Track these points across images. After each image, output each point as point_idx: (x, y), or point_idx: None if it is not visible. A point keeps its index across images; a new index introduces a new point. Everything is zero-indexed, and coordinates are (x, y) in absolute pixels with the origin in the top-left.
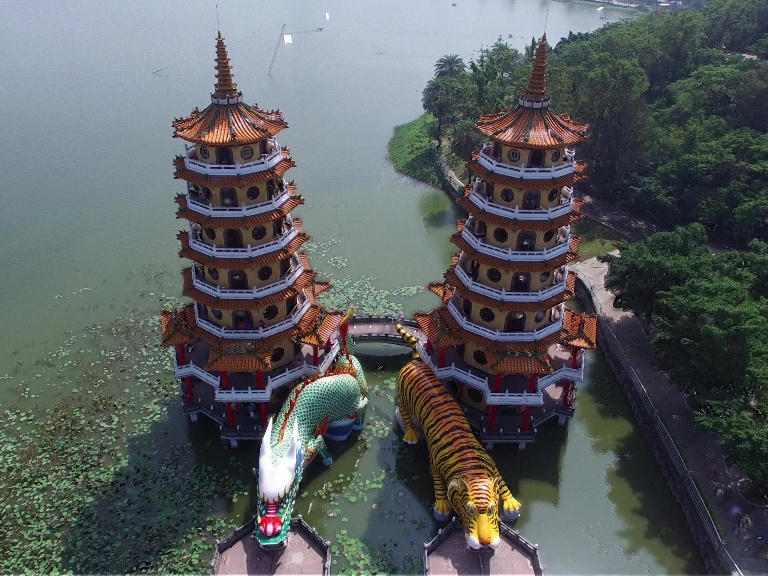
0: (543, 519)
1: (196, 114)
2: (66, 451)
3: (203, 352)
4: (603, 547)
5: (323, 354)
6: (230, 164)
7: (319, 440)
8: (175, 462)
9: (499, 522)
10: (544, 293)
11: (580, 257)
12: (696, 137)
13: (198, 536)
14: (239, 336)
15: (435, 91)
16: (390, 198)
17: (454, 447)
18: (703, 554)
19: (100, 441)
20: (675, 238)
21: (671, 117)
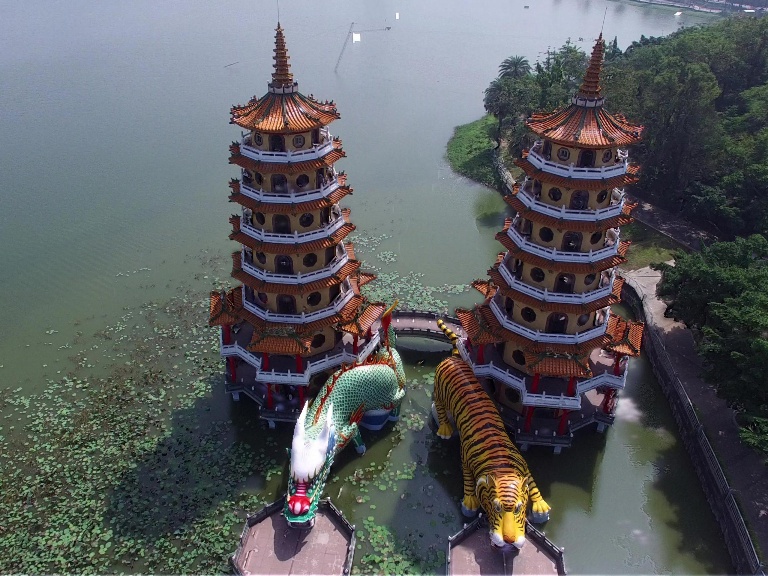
0: (573, 525)
1: (253, 102)
2: (115, 419)
3: (248, 334)
4: (634, 559)
5: (363, 344)
6: (282, 151)
7: (353, 427)
8: (215, 438)
9: (526, 522)
10: (588, 296)
11: (634, 265)
12: (767, 147)
13: (231, 509)
14: (282, 320)
15: (497, 92)
16: (445, 197)
17: (486, 444)
18: (739, 575)
19: (147, 412)
20: (734, 249)
21: (742, 125)
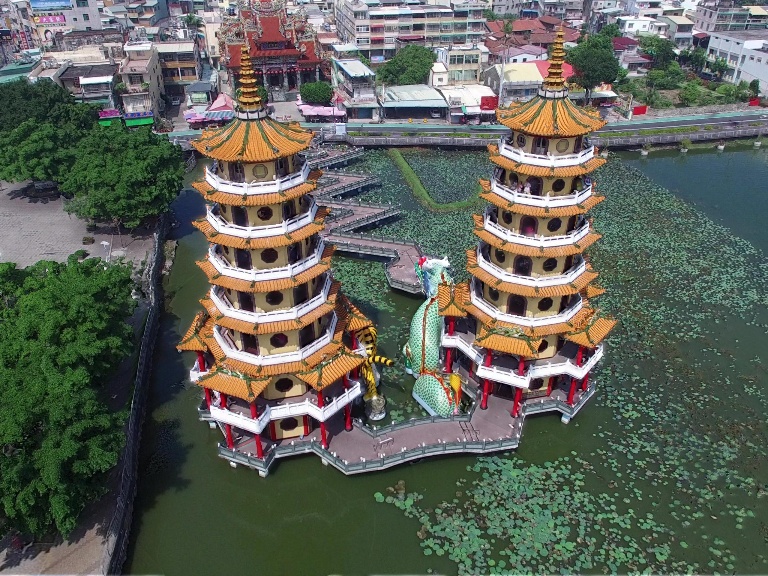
0: None
1: None
2: None
3: None
4: None
5: None
6: None
7: None
8: None
9: None
10: None
11: None
12: None
13: None
14: None
15: None
16: None
17: None
18: None
19: None
20: (8, 406)
21: None
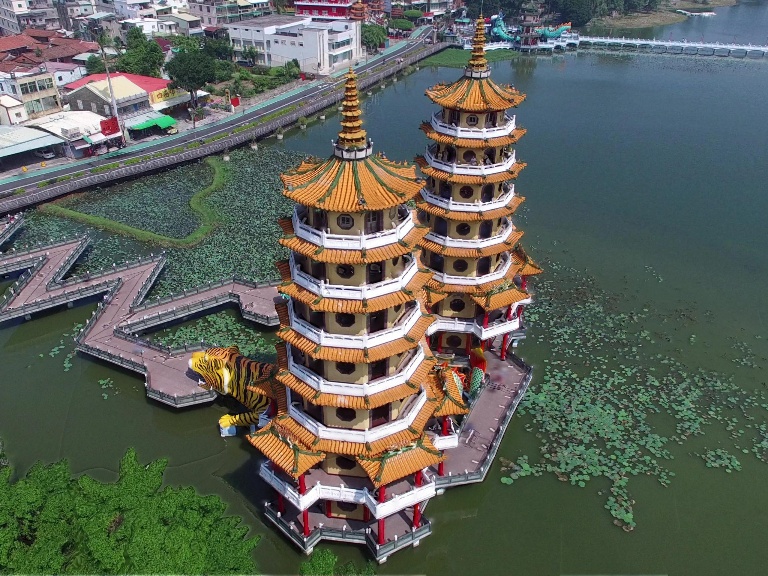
0: None
1: None
2: None
3: None
4: None
5: None
6: None
7: None
8: None
9: None
10: None
11: None
12: None
13: None
14: None
15: None
16: None
17: None
18: None
19: None
20: None
21: None
